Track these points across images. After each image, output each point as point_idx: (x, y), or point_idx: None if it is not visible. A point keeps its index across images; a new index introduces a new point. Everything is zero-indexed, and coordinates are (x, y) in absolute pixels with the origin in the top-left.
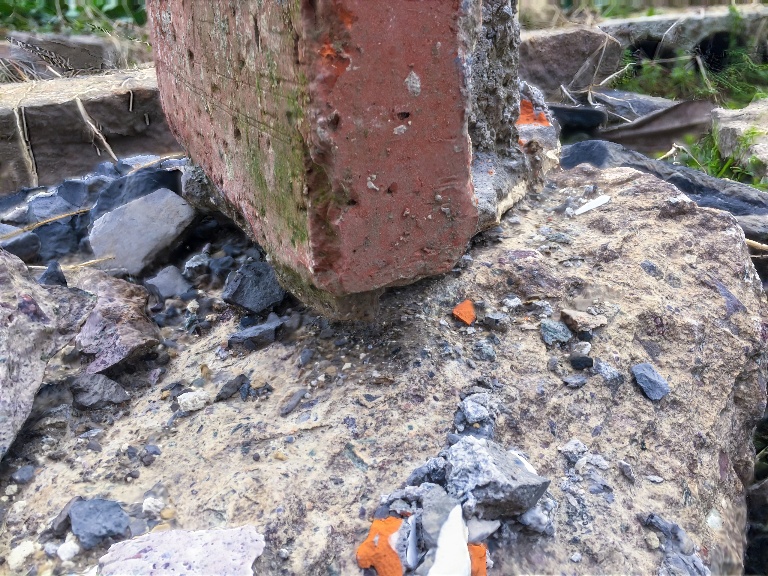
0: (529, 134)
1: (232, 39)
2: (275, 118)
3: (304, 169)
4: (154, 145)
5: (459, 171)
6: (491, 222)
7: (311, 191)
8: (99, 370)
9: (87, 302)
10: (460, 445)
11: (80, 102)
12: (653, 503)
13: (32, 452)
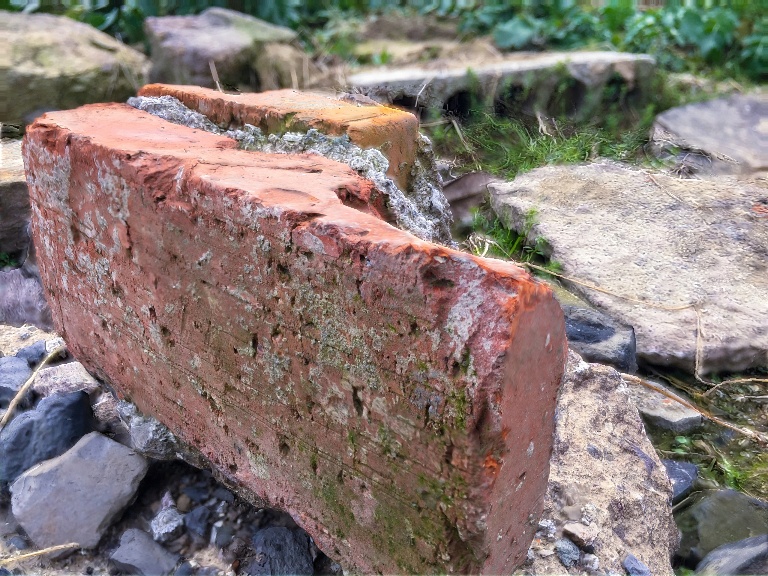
0: None
1: (297, 380)
2: (386, 479)
3: (444, 540)
4: None
5: (542, 489)
6: None
7: (453, 558)
8: None
9: None
10: None
11: None
12: None
13: None
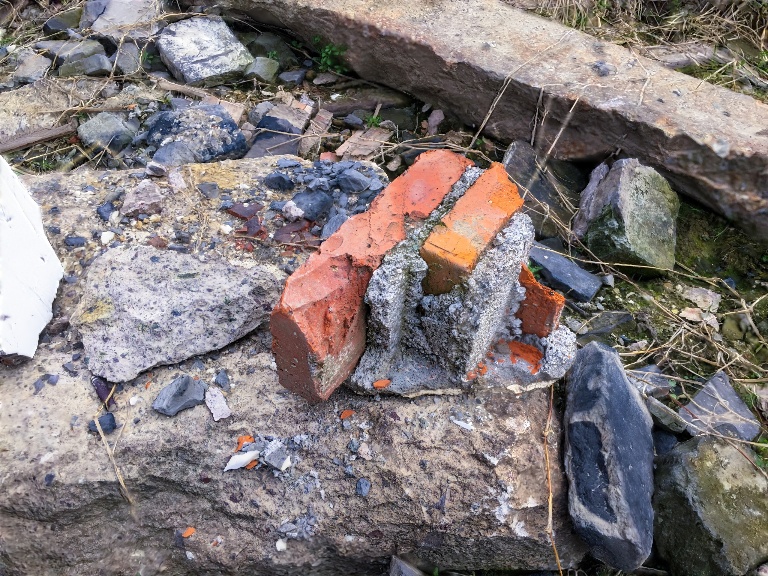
0: (513, 370)
1: None
2: None
3: None
4: (578, 137)
5: None
6: None
7: None
8: None
9: None
10: (275, 442)
11: (542, 92)
12: (322, 508)
13: (243, 344)
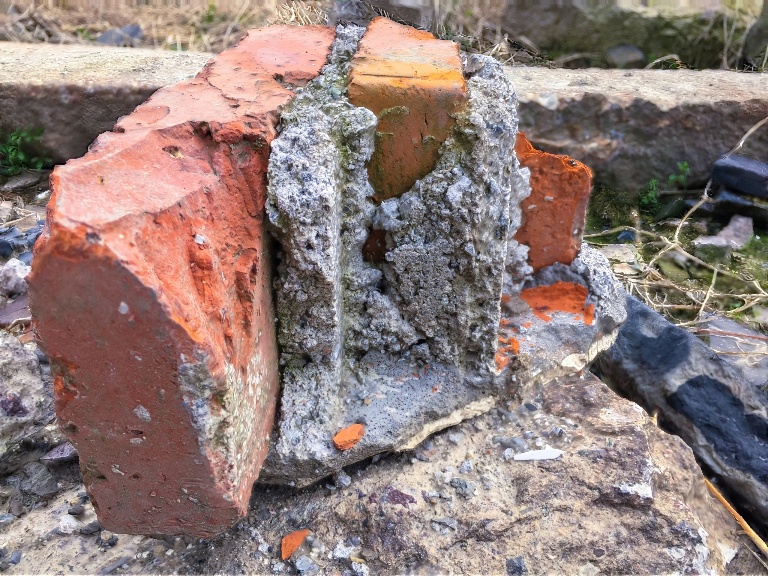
0: (556, 330)
1: None
2: None
3: None
4: None
5: (204, 476)
6: None
7: None
8: (53, 457)
9: None
10: None
11: None
12: None
13: None
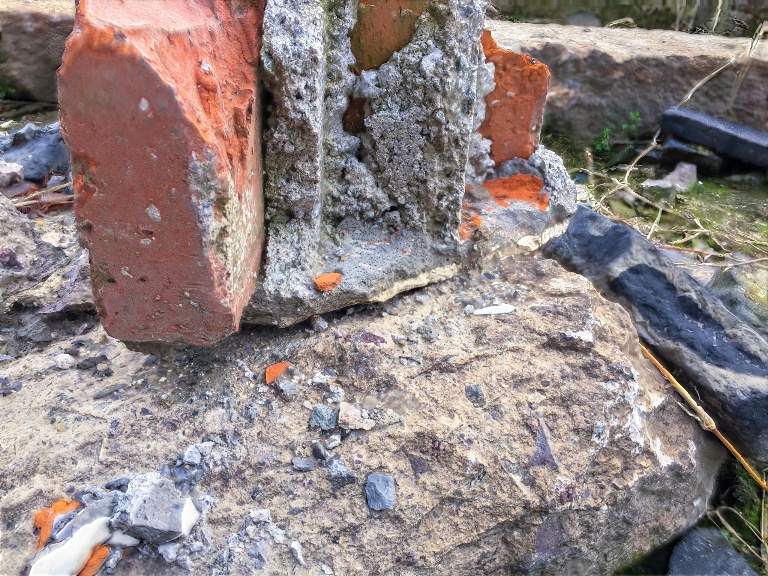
0: (513, 214)
1: None
2: None
3: None
4: None
5: (205, 279)
6: (365, 299)
7: (91, 263)
8: (46, 312)
9: (59, 261)
10: (142, 477)
11: None
12: None
13: None
